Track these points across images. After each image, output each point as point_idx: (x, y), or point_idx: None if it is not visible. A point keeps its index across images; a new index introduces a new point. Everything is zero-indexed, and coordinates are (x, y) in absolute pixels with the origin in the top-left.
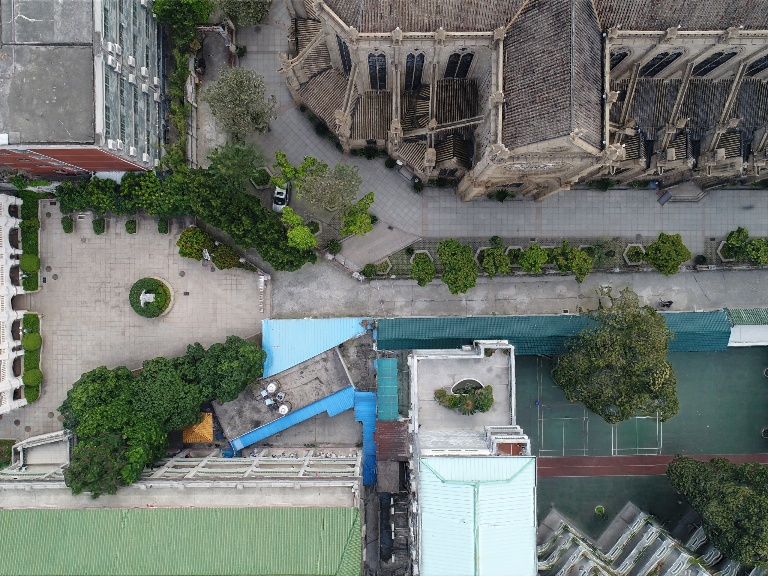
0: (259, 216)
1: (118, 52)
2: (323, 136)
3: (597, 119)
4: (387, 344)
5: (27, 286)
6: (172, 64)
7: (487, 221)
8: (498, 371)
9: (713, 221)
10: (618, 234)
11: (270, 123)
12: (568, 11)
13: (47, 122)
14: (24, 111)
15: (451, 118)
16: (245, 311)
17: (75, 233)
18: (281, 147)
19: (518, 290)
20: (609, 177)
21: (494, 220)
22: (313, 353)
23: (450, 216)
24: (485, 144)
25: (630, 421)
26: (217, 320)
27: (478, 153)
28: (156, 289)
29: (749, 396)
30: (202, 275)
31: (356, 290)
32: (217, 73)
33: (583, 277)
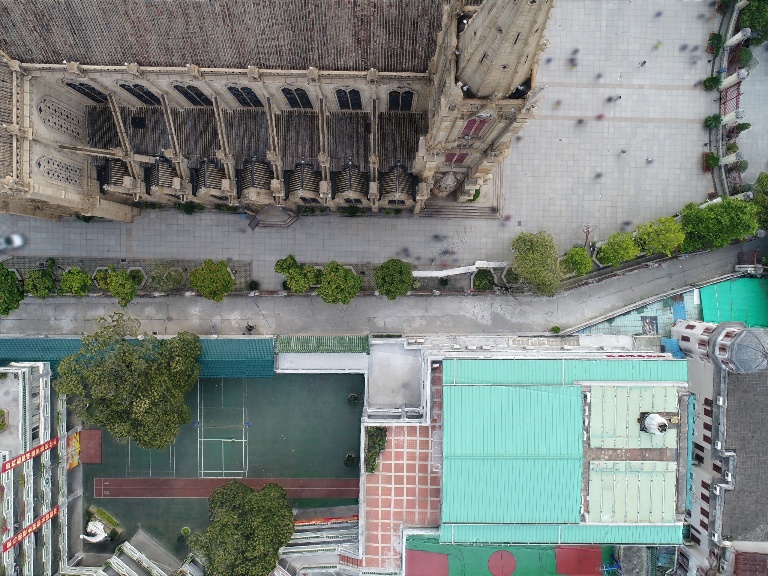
0: None
1: None
2: None
3: (2, 151)
4: None
5: None
6: None
7: (77, 241)
8: (15, 394)
9: (303, 247)
10: (209, 257)
11: None
12: None
13: None
14: None
15: None
16: None
17: None
18: None
19: (107, 311)
20: (192, 201)
21: (84, 240)
22: None
23: (40, 235)
24: None
25: (216, 444)
26: None
27: None
28: None
29: (334, 421)
30: None
31: None
32: None
33: (124, 302)
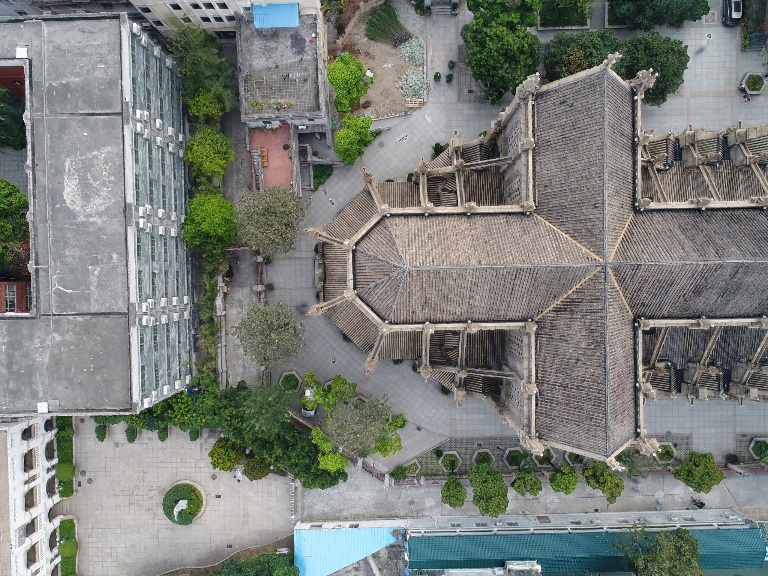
0: (290, 440)
1: (152, 307)
2: (350, 341)
3: (631, 409)
4: (419, 564)
5: (63, 493)
6: (200, 273)
7: None
8: None
9: (744, 418)
10: None
11: (297, 327)
12: (602, 333)
13: (85, 390)
14: (63, 379)
15: (480, 351)
16: (276, 513)
17: (108, 438)
18: (309, 351)
19: (548, 489)
20: None
21: None
22: (345, 563)
23: (478, 416)
24: (516, 396)
25: None
26: (249, 522)
27: (508, 390)
28: (189, 495)
29: None
30: (233, 478)
31: (386, 491)
32: (245, 280)
33: (615, 499)
